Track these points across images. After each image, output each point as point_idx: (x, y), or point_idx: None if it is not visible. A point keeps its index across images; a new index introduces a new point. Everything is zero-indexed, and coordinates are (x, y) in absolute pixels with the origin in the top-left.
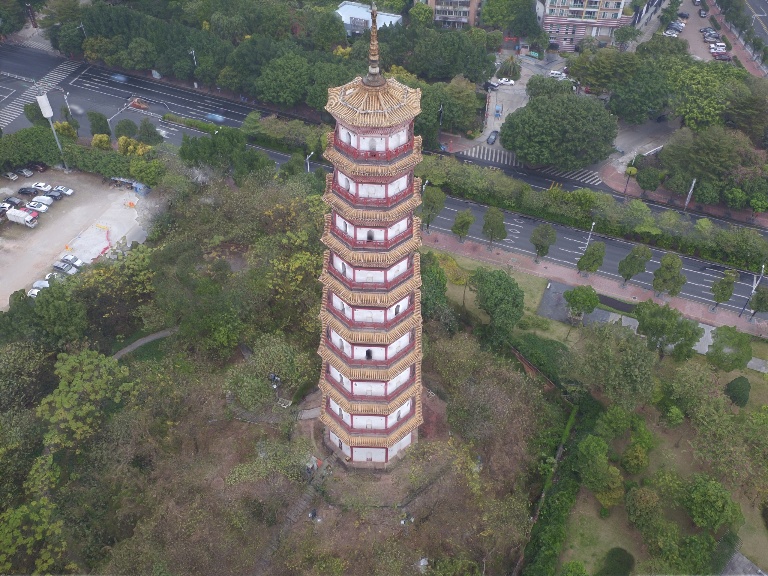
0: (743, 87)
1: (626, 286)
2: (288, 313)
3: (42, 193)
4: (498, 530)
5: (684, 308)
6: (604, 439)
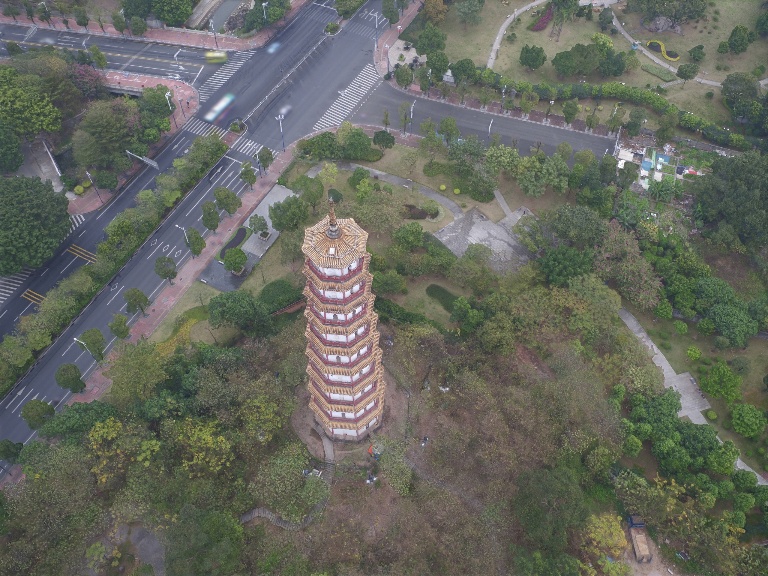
0: (31, 77)
1: (216, 232)
2: (211, 477)
3: None
4: (439, 335)
5: (246, 205)
6: (372, 272)
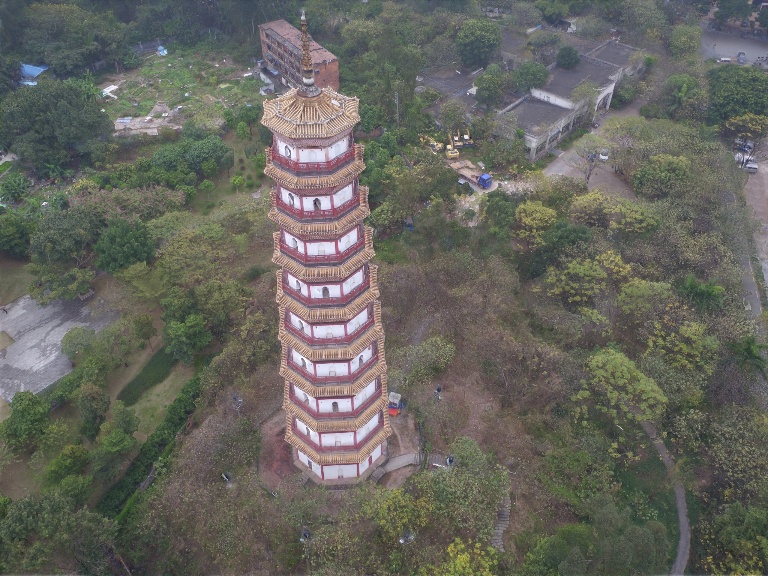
0: None
1: None
2: None
3: None
4: None
5: None
6: None
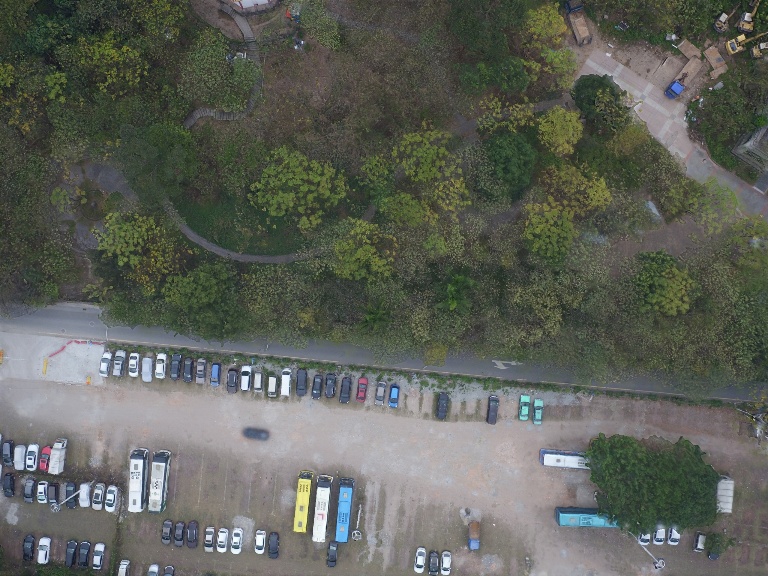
0: None
1: None
2: None
3: (5, 470)
4: None
5: None
6: None
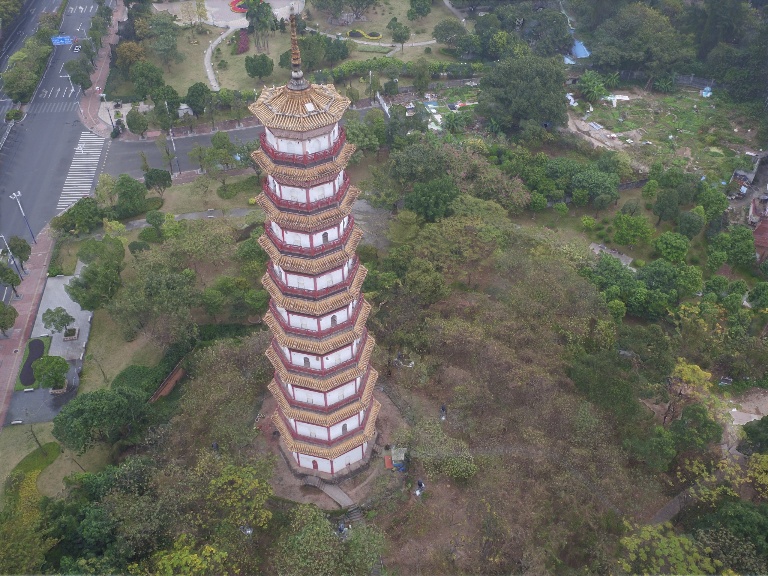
0: None
1: None
2: None
3: None
4: None
5: (21, 315)
6: None
